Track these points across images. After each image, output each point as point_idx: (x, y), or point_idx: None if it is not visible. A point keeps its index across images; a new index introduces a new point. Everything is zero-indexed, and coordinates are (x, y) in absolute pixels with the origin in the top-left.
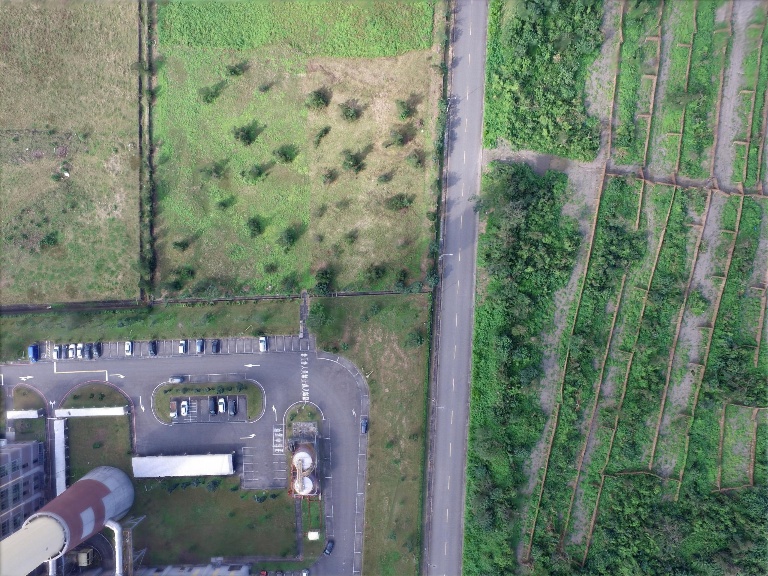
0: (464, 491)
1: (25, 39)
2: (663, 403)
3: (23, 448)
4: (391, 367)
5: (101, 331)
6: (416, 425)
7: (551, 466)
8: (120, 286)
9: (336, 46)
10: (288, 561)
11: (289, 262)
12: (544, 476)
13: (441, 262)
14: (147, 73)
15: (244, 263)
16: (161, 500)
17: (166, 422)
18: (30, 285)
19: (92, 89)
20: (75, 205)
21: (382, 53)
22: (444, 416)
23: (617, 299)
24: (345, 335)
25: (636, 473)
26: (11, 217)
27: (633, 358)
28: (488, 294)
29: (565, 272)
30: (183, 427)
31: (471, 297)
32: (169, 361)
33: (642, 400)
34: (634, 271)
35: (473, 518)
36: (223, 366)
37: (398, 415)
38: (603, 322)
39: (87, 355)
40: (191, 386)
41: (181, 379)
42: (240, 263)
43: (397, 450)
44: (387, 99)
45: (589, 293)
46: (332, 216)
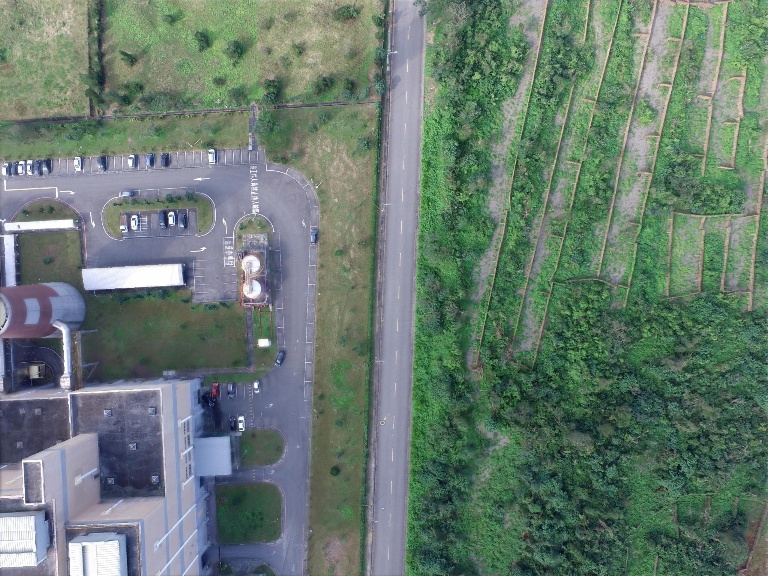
0: (414, 300)
1: None
2: (611, 211)
3: None
4: (340, 177)
5: (51, 147)
6: (365, 234)
7: (500, 272)
8: (69, 102)
9: None
10: (240, 373)
11: (238, 75)
12: (493, 281)
13: (389, 73)
14: None
15: (193, 77)
16: (112, 314)
17: (117, 237)
18: None
19: None
20: (23, 22)
21: None
22: (393, 226)
23: (565, 111)
24: (294, 147)
25: (585, 280)
26: None
27: (581, 169)
28: (436, 104)
29: (511, 77)
30: (134, 242)
31: (419, 107)
32: (119, 176)
33: (590, 207)
34: (582, 84)
35: (423, 326)
36: (173, 180)
37: (347, 224)
38: (551, 133)
39: (37, 171)
40: (141, 201)
41: (131, 193)
42: (189, 77)
43: (347, 260)
44: None
45: (536, 101)
46: (280, 28)
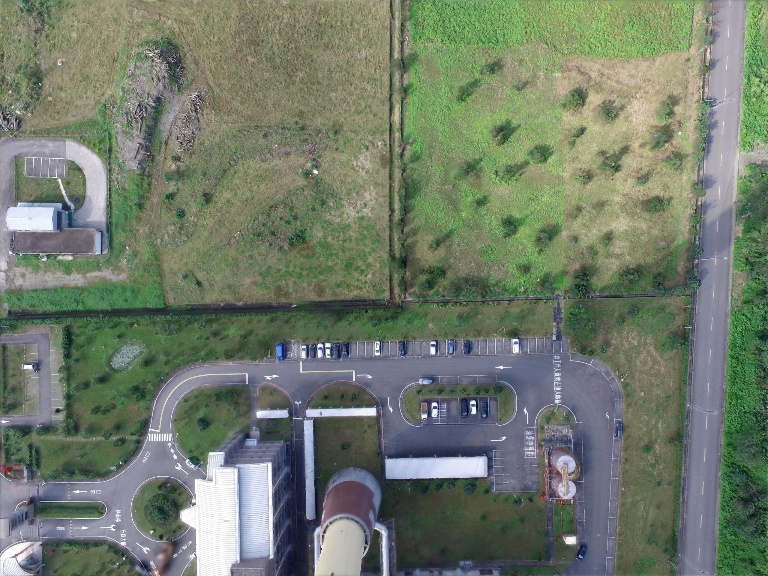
0: (718, 497)
1: (274, 34)
2: None
3: (280, 448)
4: (647, 371)
5: (349, 330)
6: (671, 429)
7: None
8: (369, 285)
9: (593, 46)
10: (538, 566)
11: (542, 263)
12: None
13: (697, 265)
14: (400, 70)
15: (496, 264)
16: (409, 502)
17: (415, 423)
18: (277, 283)
19: (342, 86)
20: (324, 203)
21: (640, 54)
22: (698, 421)
23: None
24: (599, 338)
25: None
26: (258, 214)
27: None
28: (744, 298)
29: None
30: (432, 429)
31: (727, 301)
32: (418, 362)
33: None
34: None
35: (729, 524)
36: (474, 367)
37: (654, 419)
38: None
39: (336, 355)
40: (441, 387)
41: (432, 380)
42: (492, 264)
43: (652, 455)
44: (644, 100)
45: None
46: (587, 217)
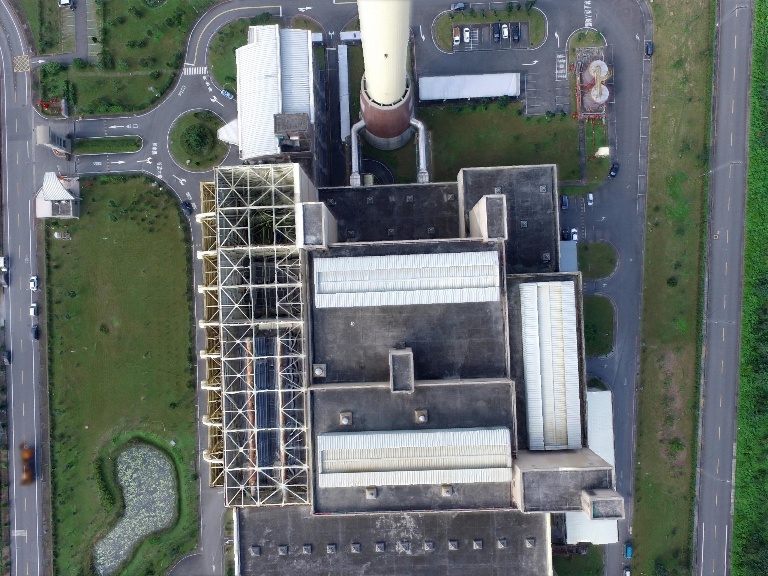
0: (748, 115)
1: None
2: None
3: None
4: None
5: None
6: (701, 48)
7: None
8: None
9: None
10: (571, 186)
11: None
12: None
13: None
14: None
15: None
16: (443, 127)
17: (447, 50)
18: None
19: None
20: None
21: None
22: (727, 41)
23: None
24: None
25: None
26: None
27: None
28: None
29: None
30: (464, 55)
31: None
32: None
33: None
34: None
35: (759, 139)
36: None
37: (684, 37)
38: None
39: None
40: (473, 14)
41: (464, 5)
42: None
43: (682, 73)
44: None
45: None
46: None
